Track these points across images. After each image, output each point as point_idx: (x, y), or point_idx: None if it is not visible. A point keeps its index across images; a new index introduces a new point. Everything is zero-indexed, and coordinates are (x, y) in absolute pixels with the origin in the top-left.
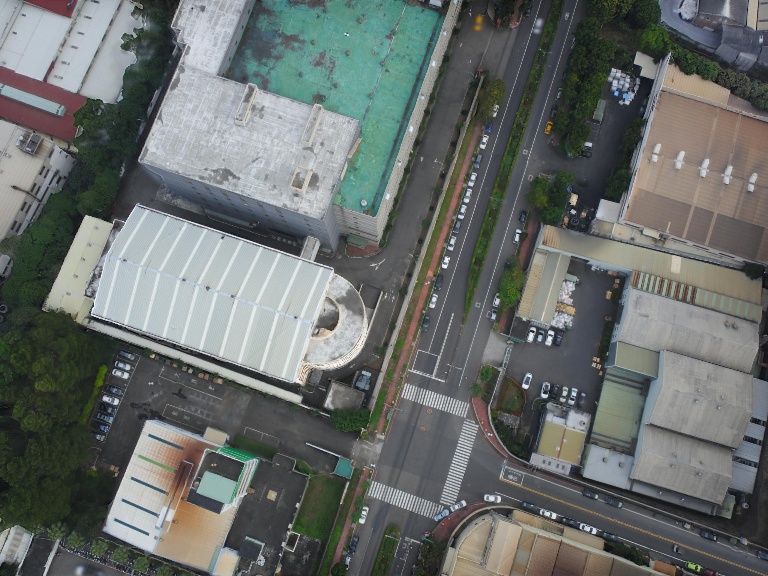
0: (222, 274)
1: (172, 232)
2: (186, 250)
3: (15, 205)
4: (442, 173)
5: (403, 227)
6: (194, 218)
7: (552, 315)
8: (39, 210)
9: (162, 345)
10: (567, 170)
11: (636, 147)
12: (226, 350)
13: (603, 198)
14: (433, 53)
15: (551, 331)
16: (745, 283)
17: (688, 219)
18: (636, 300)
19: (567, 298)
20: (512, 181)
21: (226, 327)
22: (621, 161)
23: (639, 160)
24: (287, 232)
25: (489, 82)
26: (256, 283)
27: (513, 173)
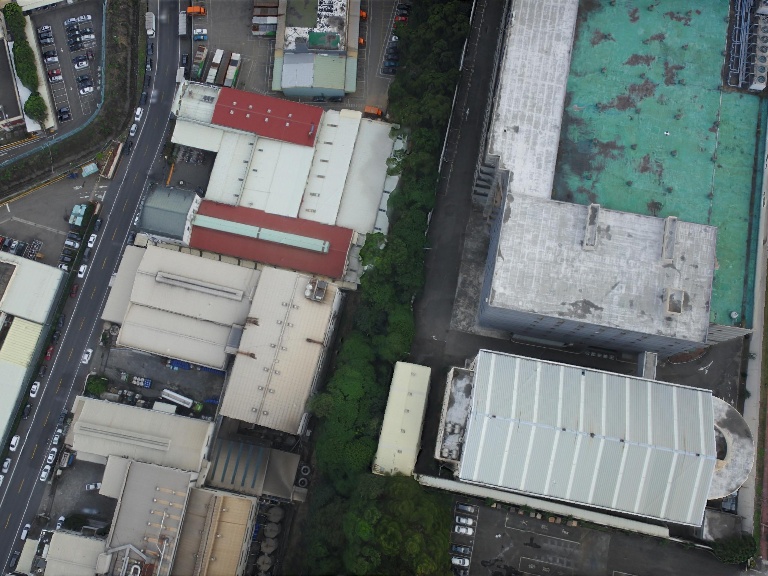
0: (600, 416)
1: (529, 375)
2: (552, 394)
3: (312, 359)
4: None
5: None
6: (497, 344)
7: None
8: (323, 357)
9: (502, 492)
10: None
11: None
12: (619, 500)
13: None
14: None
15: None
16: None
17: None
18: None
19: None
20: None
21: (617, 475)
22: None
23: None
24: (613, 348)
25: None
26: (640, 421)
27: None
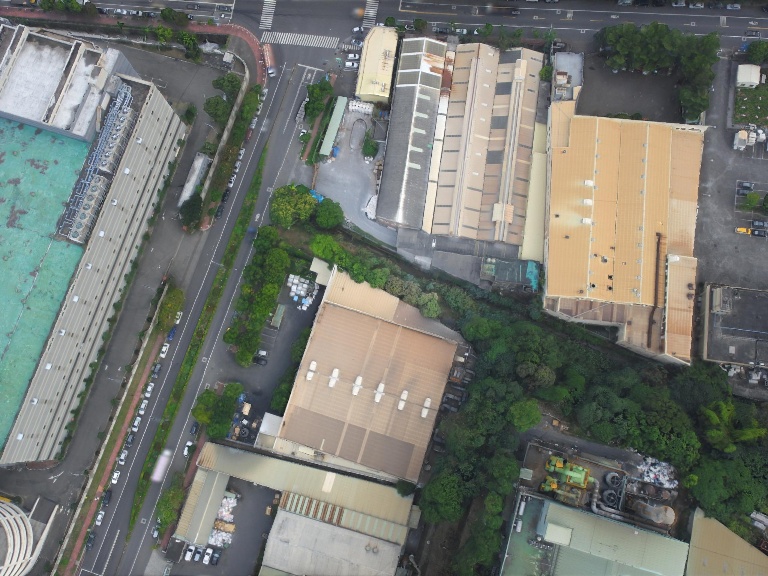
0: None
1: None
2: None
3: None
4: (124, 382)
5: (83, 438)
6: None
7: (207, 535)
8: None
9: None
10: (243, 378)
11: (301, 359)
12: None
13: (267, 411)
14: (68, 293)
15: (209, 549)
16: (395, 501)
17: (341, 436)
18: (281, 524)
19: (227, 514)
20: (189, 390)
21: None
22: (286, 374)
23: (296, 377)
24: None
25: (175, 288)
26: None
27: (190, 382)
